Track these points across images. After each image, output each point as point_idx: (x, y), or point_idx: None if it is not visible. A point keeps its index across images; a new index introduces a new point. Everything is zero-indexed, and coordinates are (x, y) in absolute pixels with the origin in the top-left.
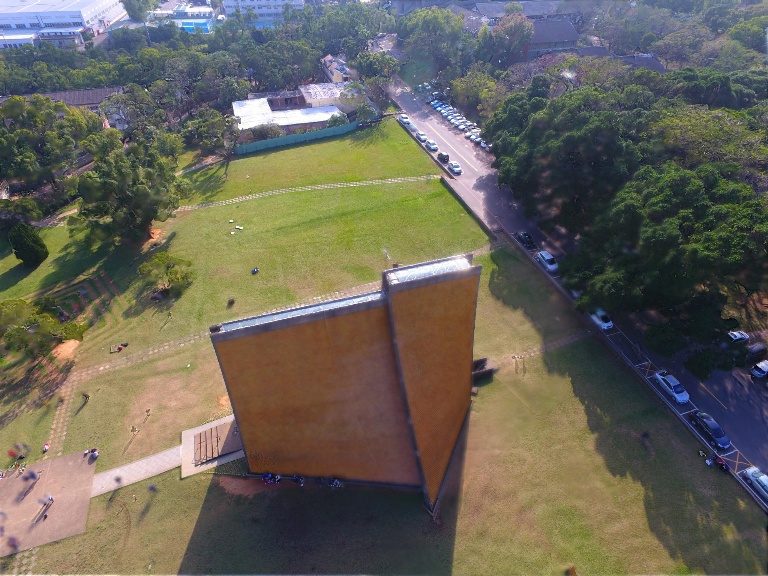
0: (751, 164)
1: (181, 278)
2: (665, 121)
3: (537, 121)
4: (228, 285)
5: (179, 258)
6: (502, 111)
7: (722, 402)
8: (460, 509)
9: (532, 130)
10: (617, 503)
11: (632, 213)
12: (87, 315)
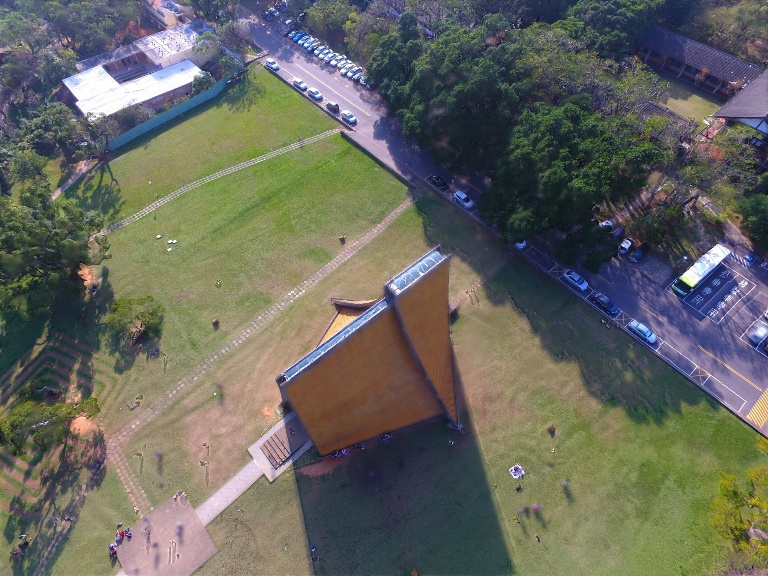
0: (596, 91)
1: (149, 315)
2: (527, 58)
3: (423, 72)
4: (201, 307)
5: (131, 294)
6: (379, 54)
7: (607, 280)
8: (474, 418)
9: (420, 80)
10: (564, 374)
11: (527, 159)
12: (78, 383)
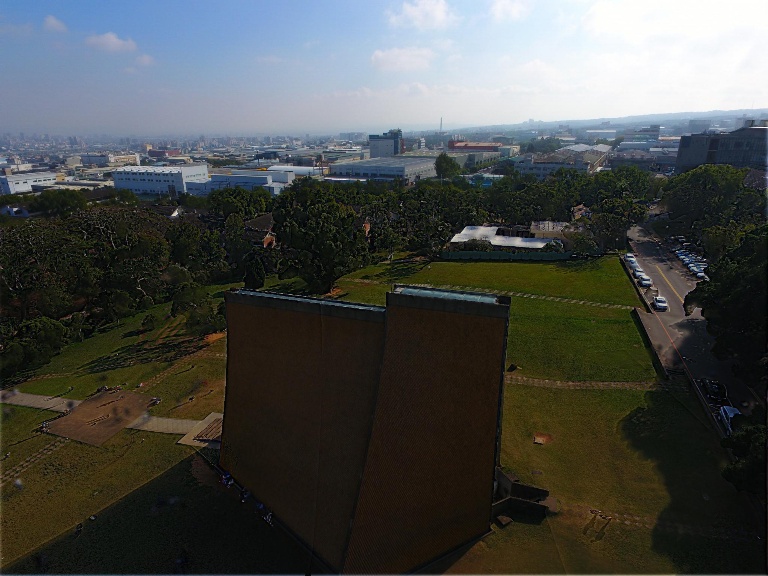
0: None
1: None
2: None
3: (767, 241)
4: None
5: None
6: (740, 244)
7: None
8: None
9: (761, 254)
10: None
11: None
12: None
